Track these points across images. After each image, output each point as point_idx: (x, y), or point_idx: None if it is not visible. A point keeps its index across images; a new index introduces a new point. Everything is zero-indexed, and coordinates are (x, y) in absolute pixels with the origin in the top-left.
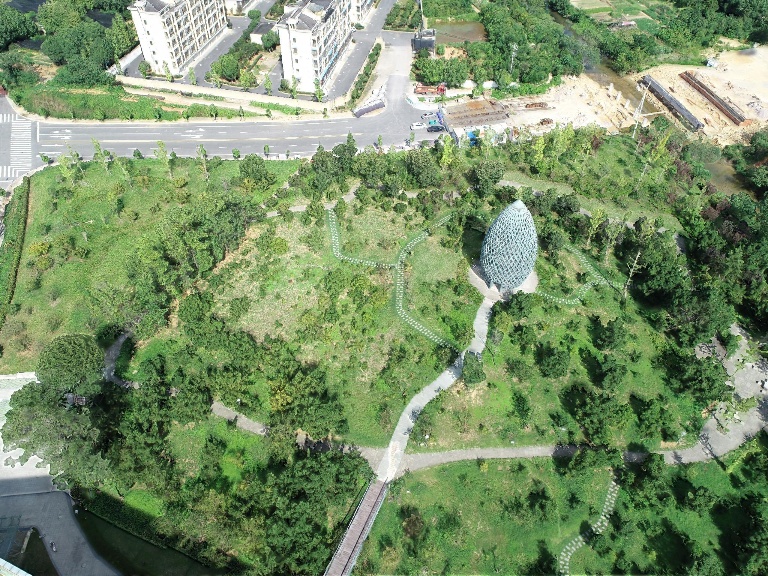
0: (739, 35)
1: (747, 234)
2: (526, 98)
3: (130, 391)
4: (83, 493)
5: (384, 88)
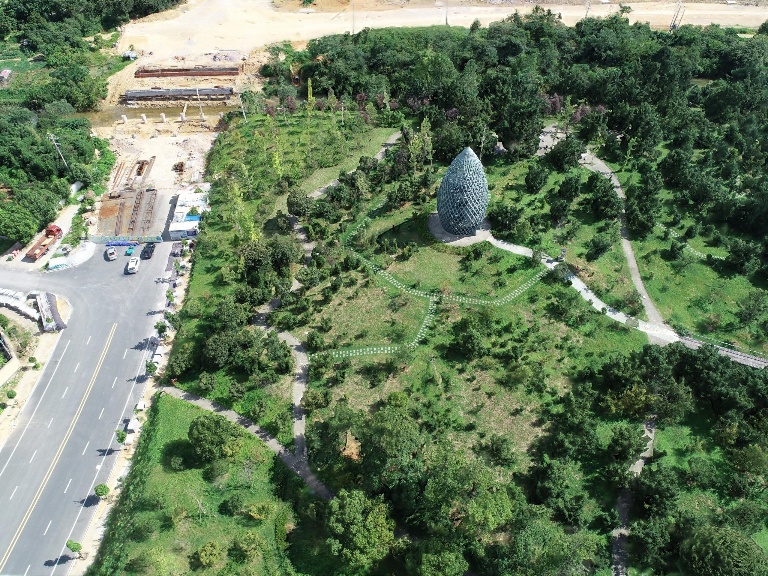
0: (95, 30)
1: (424, 97)
2: (119, 172)
3: None
4: None
5: (1, 290)
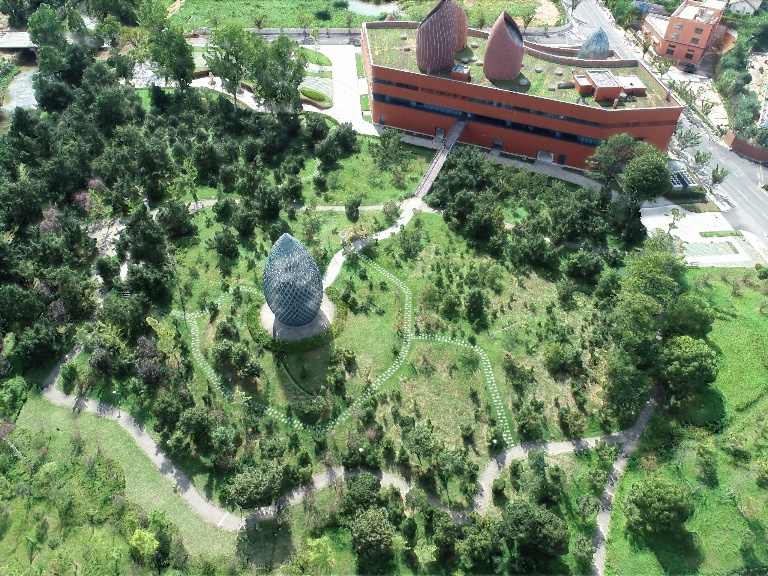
0: None
1: None
2: None
3: None
4: None
5: None
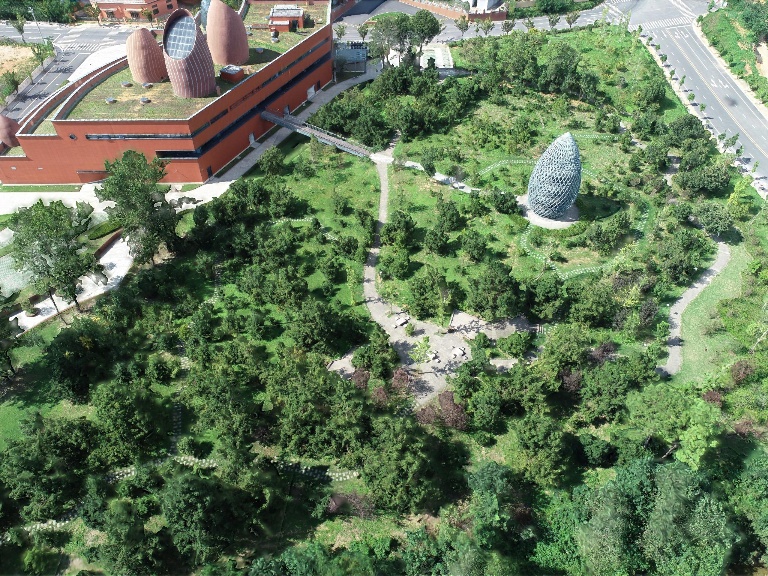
0: None
1: None
2: None
3: (436, 79)
4: None
5: None
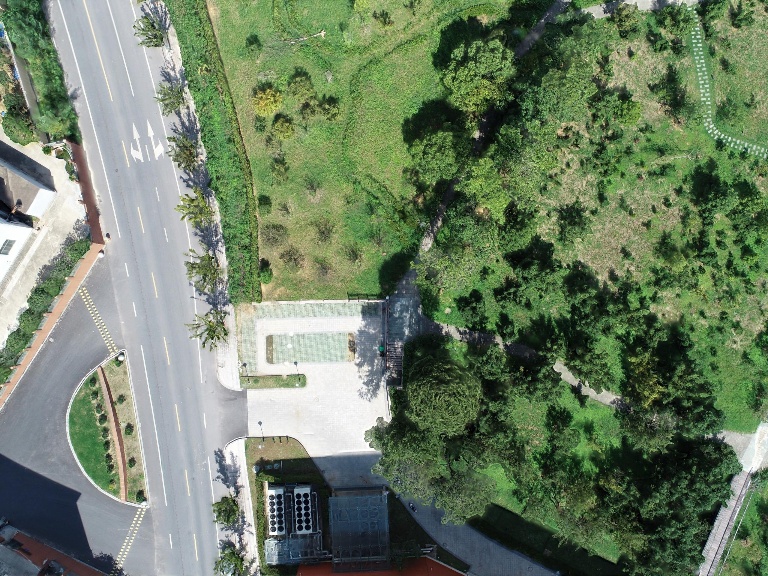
0: None
1: None
2: None
3: (451, 342)
4: None
5: None
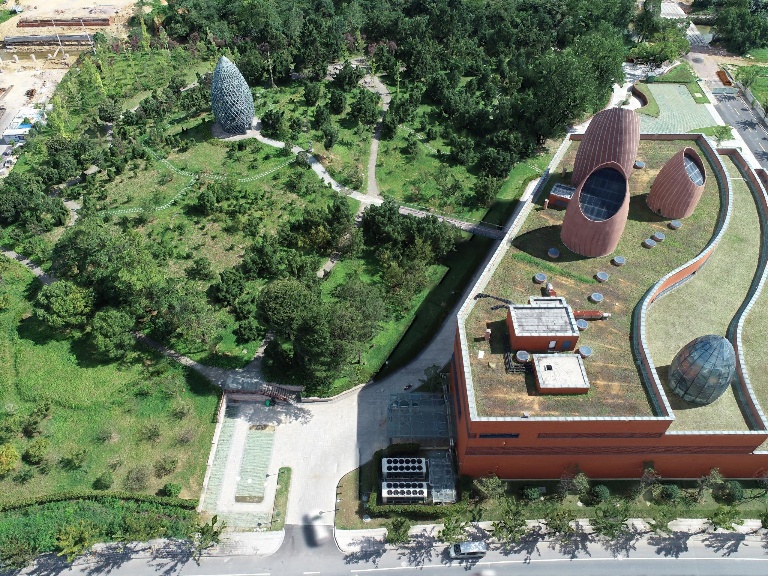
0: None
1: (247, 36)
2: None
3: None
4: (365, 373)
5: None
